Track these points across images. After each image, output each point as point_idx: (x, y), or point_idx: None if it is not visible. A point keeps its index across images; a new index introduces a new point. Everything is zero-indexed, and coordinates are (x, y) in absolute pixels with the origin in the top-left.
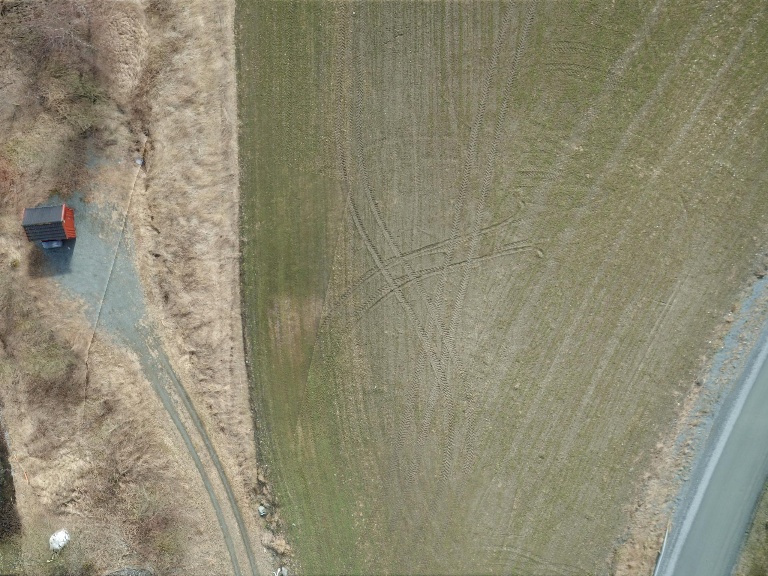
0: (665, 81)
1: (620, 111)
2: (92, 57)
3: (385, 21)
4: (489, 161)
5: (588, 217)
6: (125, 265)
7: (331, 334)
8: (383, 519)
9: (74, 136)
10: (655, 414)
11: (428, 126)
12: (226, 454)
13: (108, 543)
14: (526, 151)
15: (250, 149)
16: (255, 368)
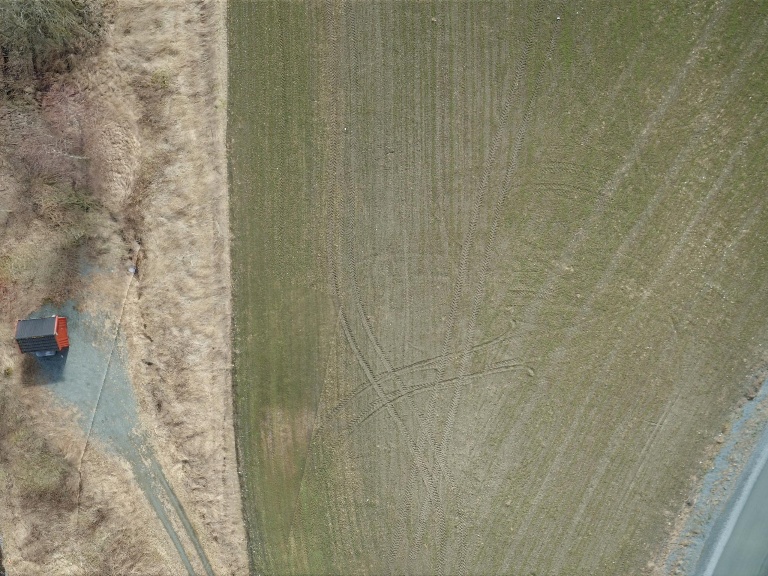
0: (655, 203)
1: (610, 232)
2: (85, 165)
3: (376, 138)
4: (480, 279)
5: (579, 337)
6: (118, 373)
7: (323, 446)
8: None
9: (67, 244)
10: (646, 533)
11: (419, 243)
12: (219, 563)
13: None
14: (517, 270)
15: (242, 262)
16: (248, 479)
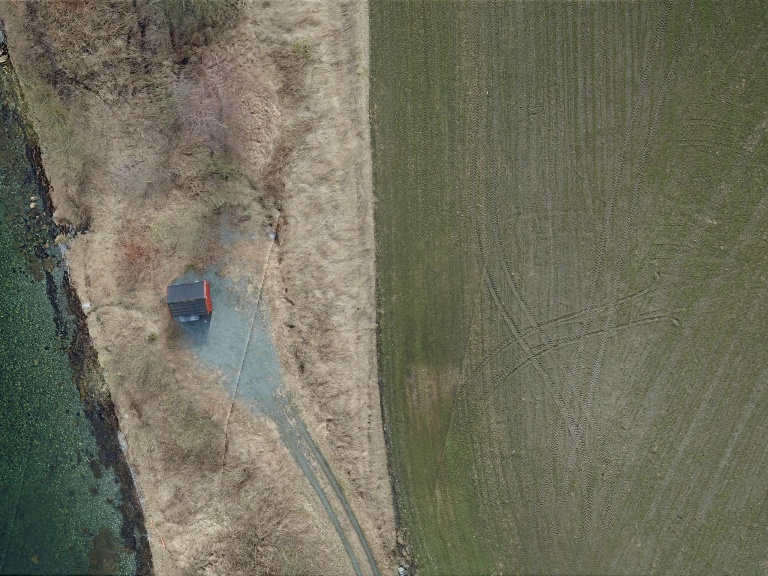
0: None
1: (752, 185)
2: (223, 135)
3: (519, 100)
4: (624, 234)
5: (723, 287)
6: (261, 337)
7: (468, 401)
8: None
9: (208, 212)
10: None
11: (563, 201)
12: (365, 518)
13: None
14: (660, 224)
15: (386, 224)
16: (393, 435)
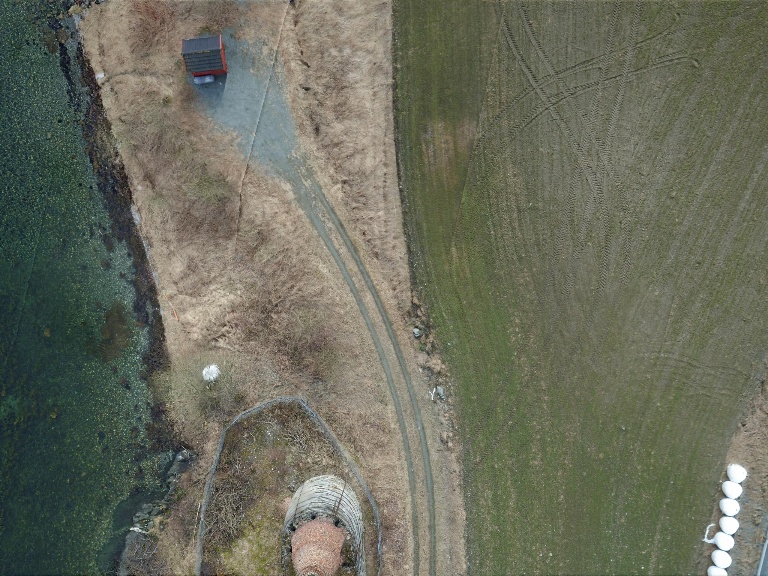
0: None
1: None
2: None
3: None
4: None
5: (743, 25)
6: (276, 98)
7: (485, 155)
8: (539, 333)
9: None
10: None
11: None
12: (380, 278)
13: (259, 375)
14: None
15: None
16: (409, 192)
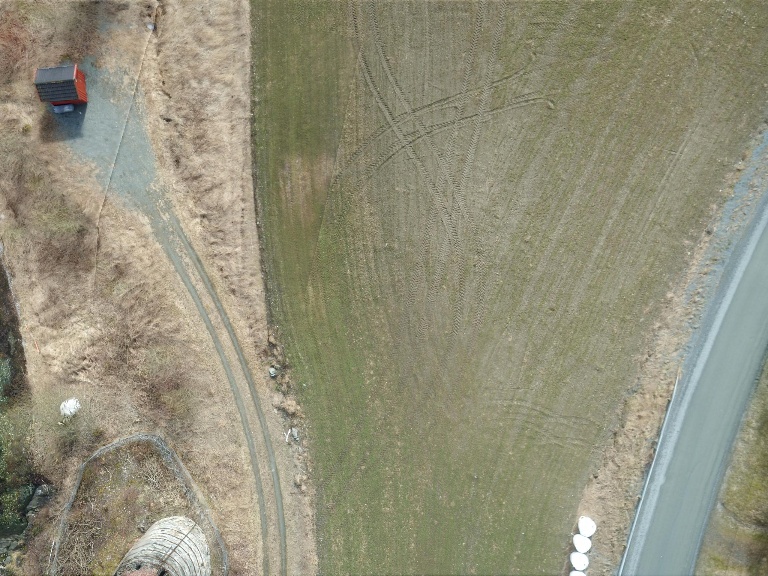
0: None
1: None
2: None
3: None
4: (500, 13)
5: (599, 67)
6: (136, 129)
7: (342, 193)
8: (393, 377)
9: (86, 1)
10: (665, 264)
11: None
12: (237, 316)
13: (119, 411)
14: (537, 2)
15: (262, 8)
16: (266, 229)
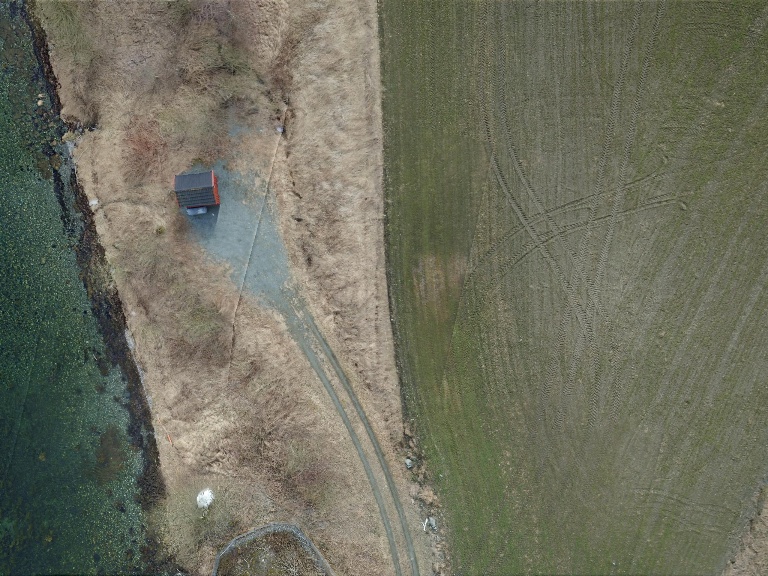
0: None
1: (760, 67)
2: (231, 29)
3: None
4: (632, 118)
5: (731, 170)
6: (269, 230)
7: (476, 290)
8: (530, 467)
9: (216, 106)
10: None
11: (571, 86)
12: (373, 410)
13: (253, 501)
14: (668, 108)
15: (394, 113)
16: (400, 325)
